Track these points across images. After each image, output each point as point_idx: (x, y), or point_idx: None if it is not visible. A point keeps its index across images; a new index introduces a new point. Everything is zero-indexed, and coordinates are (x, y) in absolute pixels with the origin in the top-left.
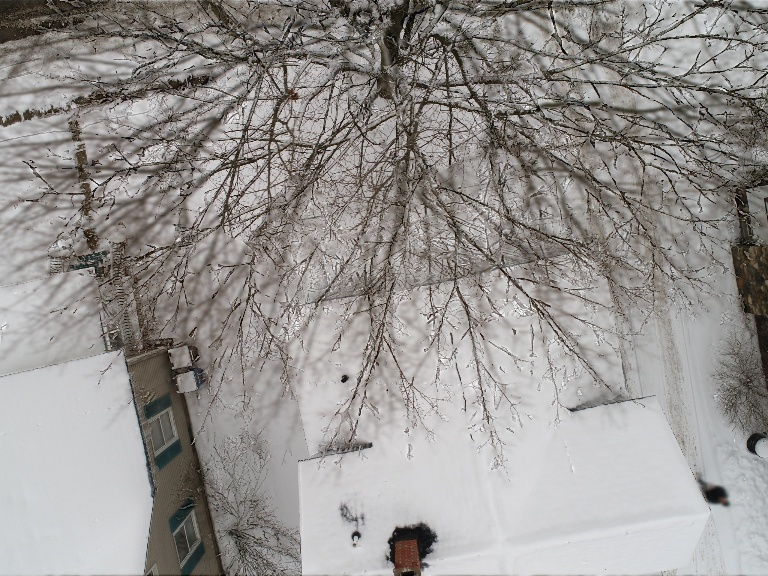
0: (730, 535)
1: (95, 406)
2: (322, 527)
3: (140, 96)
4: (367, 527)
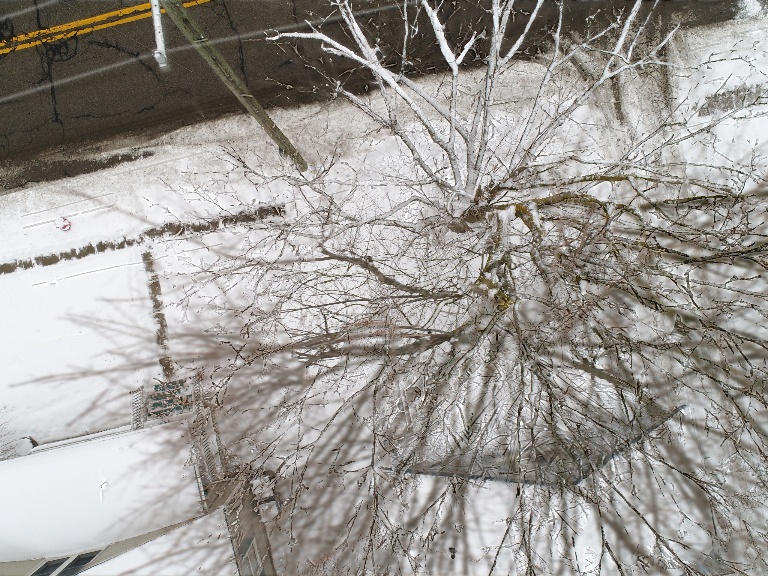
0: None
1: (201, 569)
2: None
3: (239, 272)
4: None
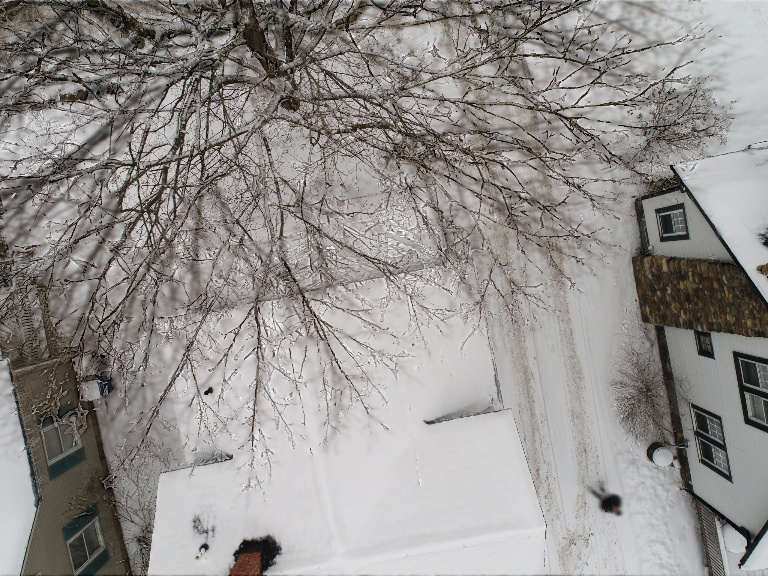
0: (632, 543)
1: None
2: (172, 539)
3: (16, 109)
4: (216, 539)
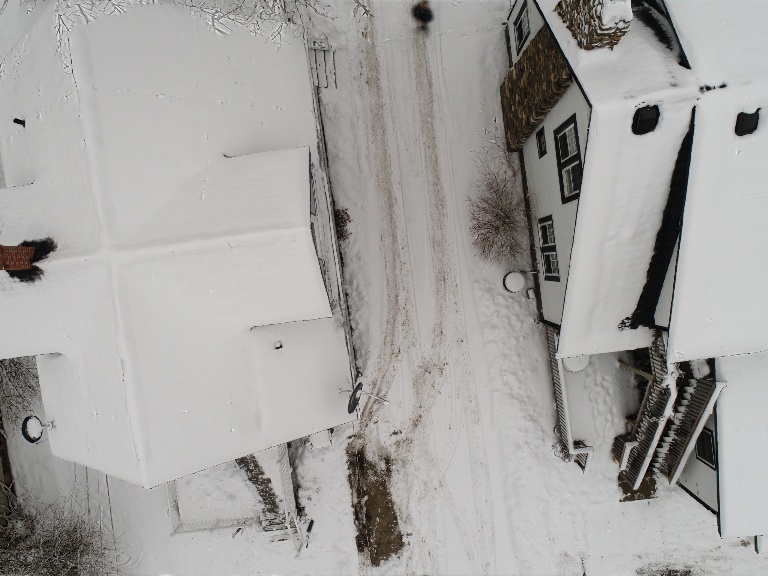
0: (485, 373)
1: None
2: None
3: None
4: None
